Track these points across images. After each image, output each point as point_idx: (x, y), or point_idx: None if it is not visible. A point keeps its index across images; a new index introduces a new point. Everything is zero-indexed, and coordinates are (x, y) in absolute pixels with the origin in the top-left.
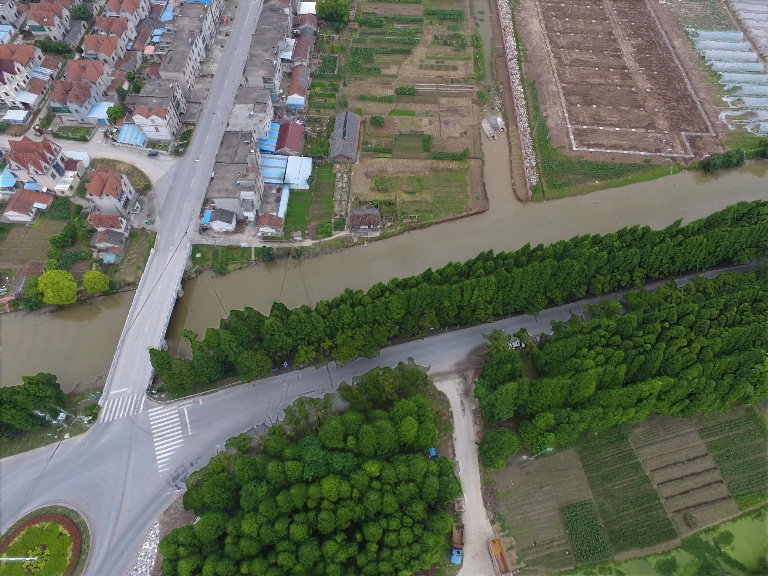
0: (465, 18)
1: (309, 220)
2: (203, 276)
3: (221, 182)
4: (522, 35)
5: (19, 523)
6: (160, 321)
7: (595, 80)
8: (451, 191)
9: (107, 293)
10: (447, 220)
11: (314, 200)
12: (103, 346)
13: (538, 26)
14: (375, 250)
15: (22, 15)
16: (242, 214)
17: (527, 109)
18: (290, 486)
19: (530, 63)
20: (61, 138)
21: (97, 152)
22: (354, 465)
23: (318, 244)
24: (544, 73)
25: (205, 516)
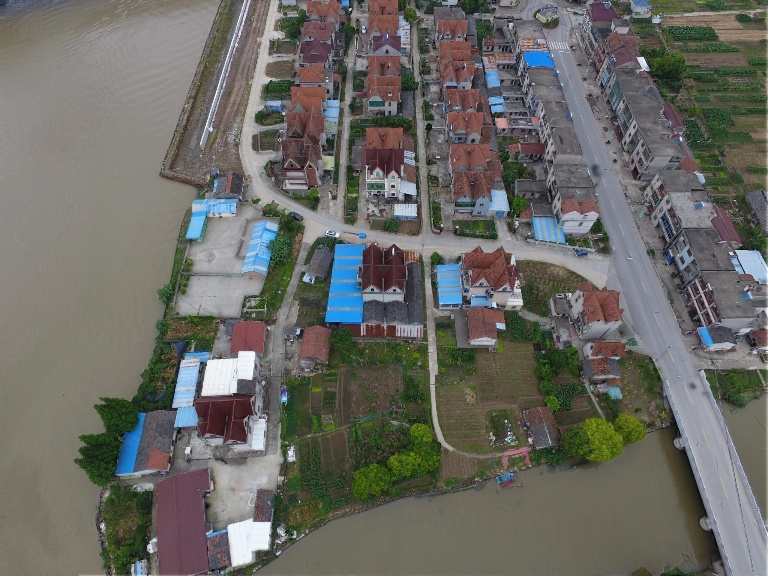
0: None
1: None
2: None
3: (725, 296)
4: None
5: None
6: None
7: None
8: None
9: None
10: None
11: None
12: (625, 500)
13: None
14: None
15: None
16: (737, 330)
17: None
18: None
19: None
20: (466, 236)
21: (515, 252)
22: None
23: None
24: None
25: None
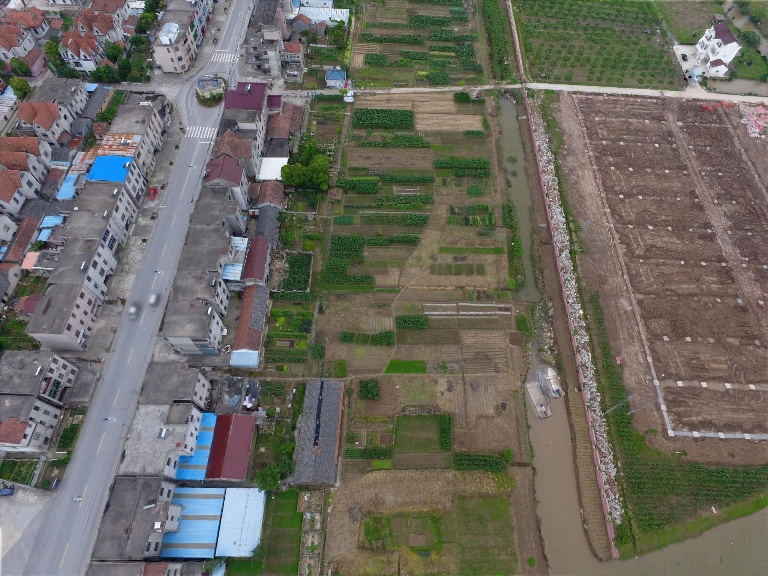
0: (491, 173)
1: None
2: None
3: None
4: (572, 202)
5: None
6: None
7: (683, 286)
8: (487, 545)
9: None
10: None
11: None
12: None
13: (593, 184)
14: None
15: None
16: None
17: (592, 351)
18: None
19: (588, 256)
20: None
21: None
22: None
23: None
24: (610, 275)
25: None
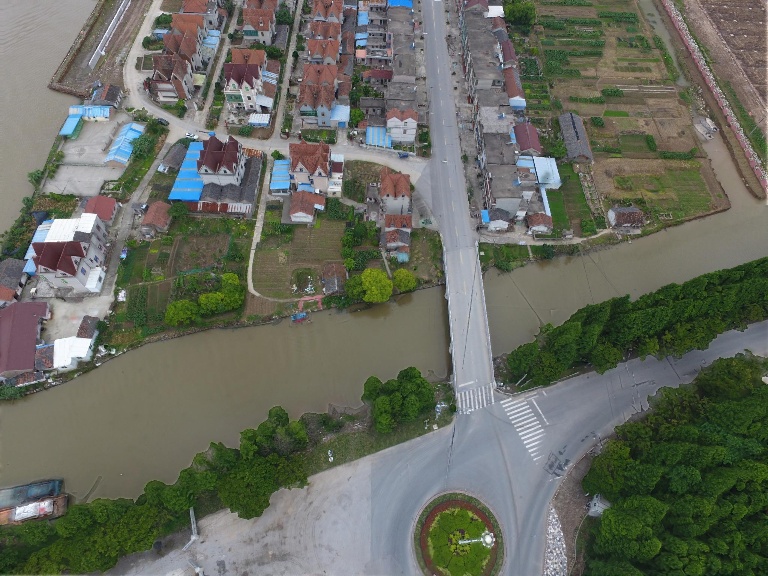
0: (640, 20)
1: (569, 219)
2: (490, 273)
3: (501, 182)
4: (699, 37)
5: (427, 510)
6: (479, 317)
7: None
8: (691, 189)
9: (407, 291)
10: (697, 217)
11: (566, 199)
12: (404, 342)
13: (711, 28)
14: (640, 247)
15: (224, 20)
16: (515, 213)
17: (732, 109)
18: (712, 470)
19: (717, 64)
20: (308, 141)
21: (348, 154)
22: (762, 450)
23: (587, 242)
24: (734, 74)
25: (648, 499)
